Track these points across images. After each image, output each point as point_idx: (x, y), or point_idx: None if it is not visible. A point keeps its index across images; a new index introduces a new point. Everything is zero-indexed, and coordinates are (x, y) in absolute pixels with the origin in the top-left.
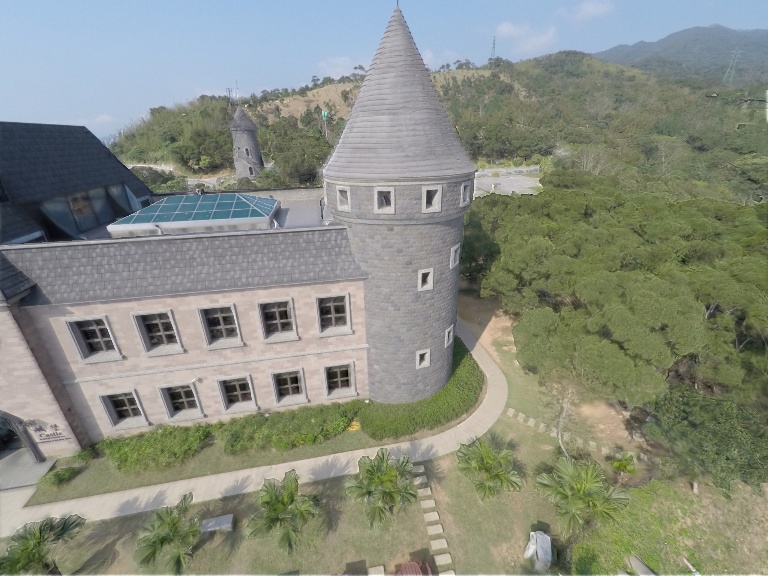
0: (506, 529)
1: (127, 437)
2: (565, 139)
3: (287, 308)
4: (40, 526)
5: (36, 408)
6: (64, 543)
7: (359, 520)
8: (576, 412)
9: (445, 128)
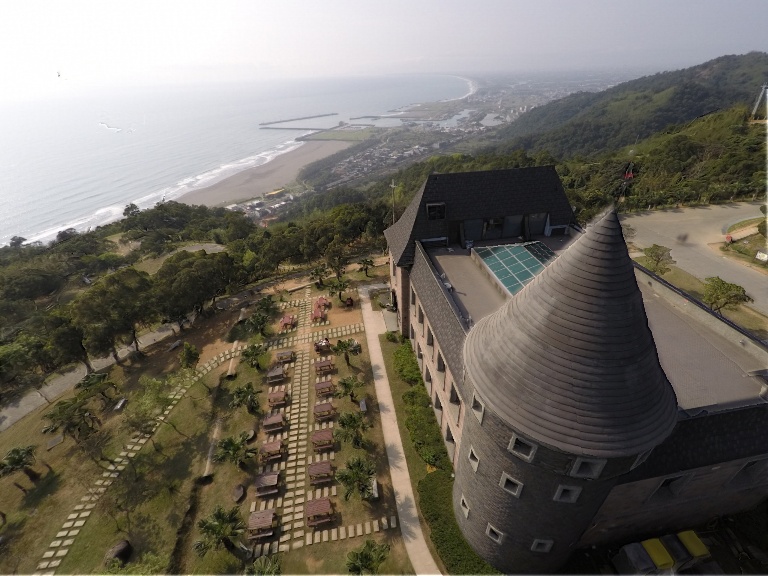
0: None
1: None
2: None
3: None
4: None
5: None
6: None
7: None
8: None
9: (539, 370)
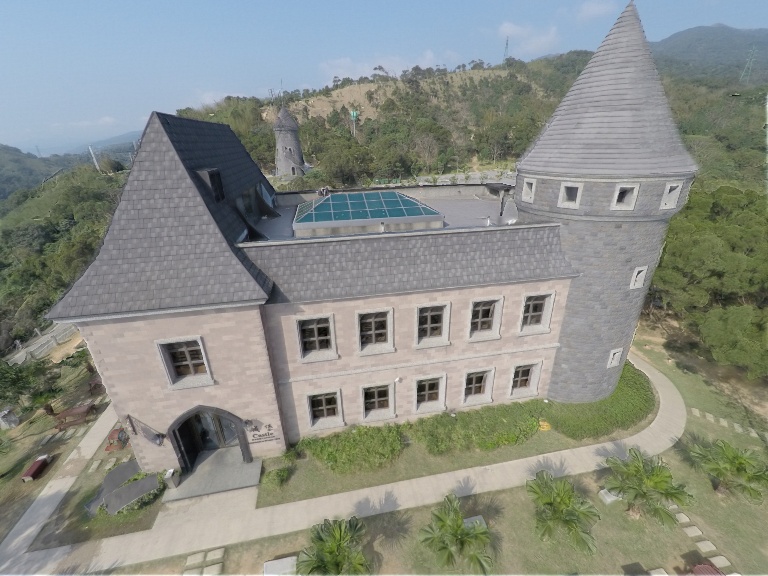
0: (765, 531)
1: (321, 437)
2: None
3: (491, 306)
4: (339, 528)
5: (256, 408)
6: (356, 545)
7: (609, 522)
8: (763, 412)
9: (679, 123)
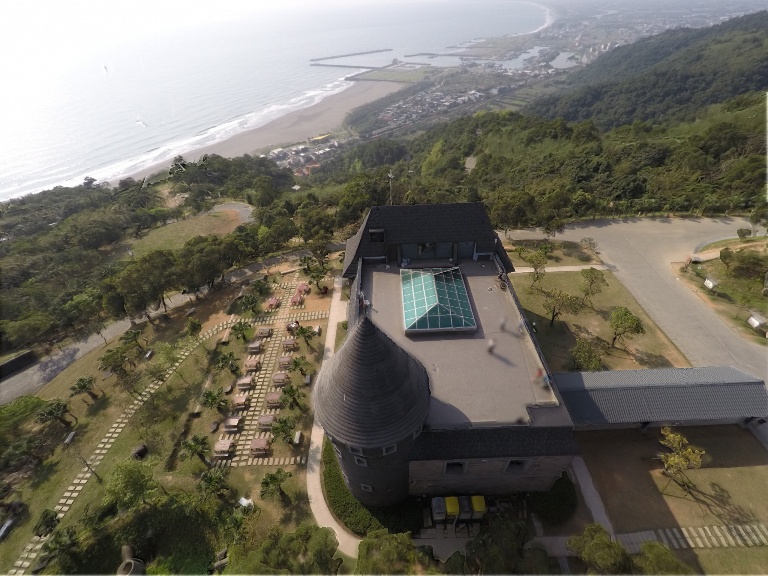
0: None
1: None
2: None
3: None
4: (307, 330)
5: None
6: None
7: None
8: None
9: (333, 394)
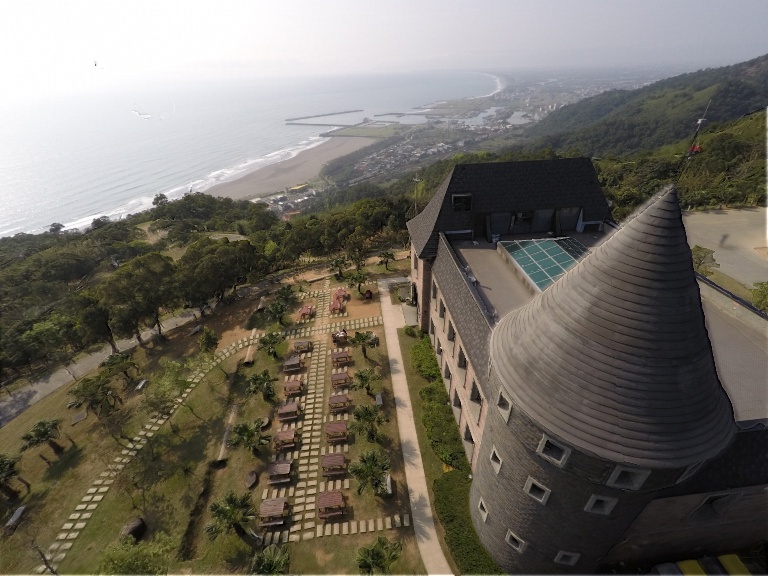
0: None
1: (431, 343)
2: None
3: None
4: (367, 335)
5: None
6: None
7: None
8: None
9: (576, 367)
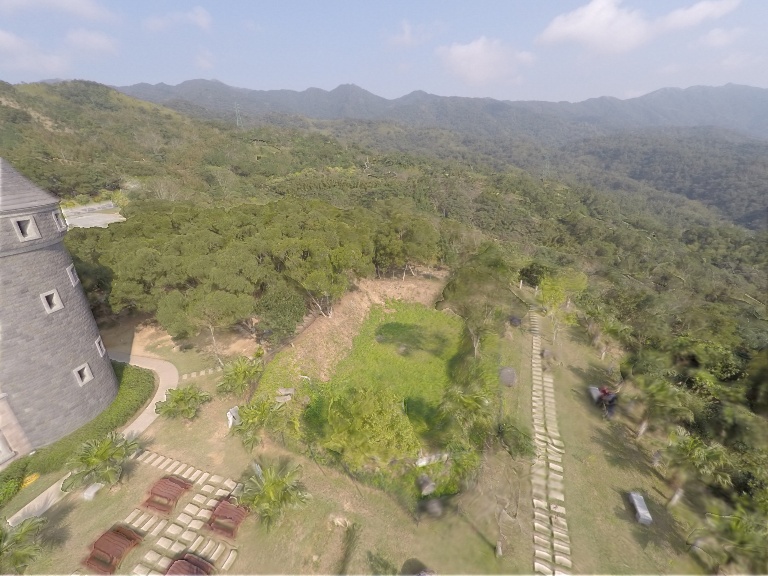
0: (213, 427)
1: None
2: (127, 173)
3: None
4: None
5: None
6: None
7: (93, 512)
8: (227, 352)
9: (8, 168)
